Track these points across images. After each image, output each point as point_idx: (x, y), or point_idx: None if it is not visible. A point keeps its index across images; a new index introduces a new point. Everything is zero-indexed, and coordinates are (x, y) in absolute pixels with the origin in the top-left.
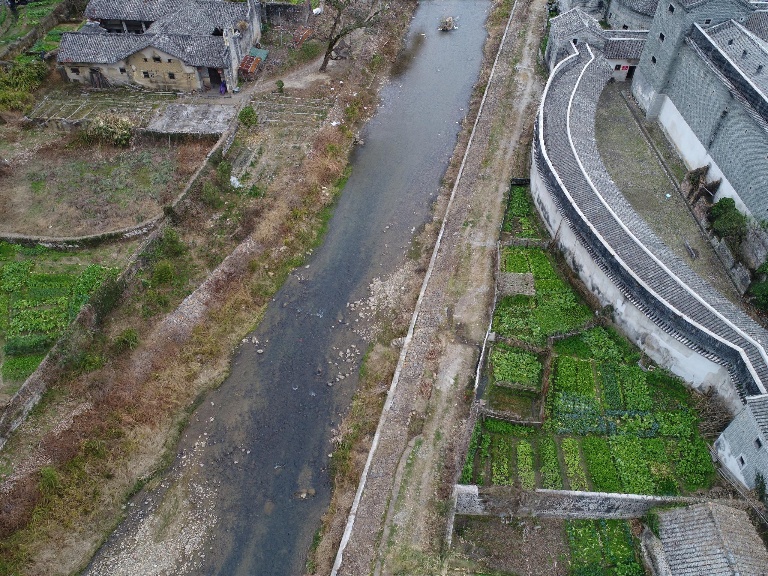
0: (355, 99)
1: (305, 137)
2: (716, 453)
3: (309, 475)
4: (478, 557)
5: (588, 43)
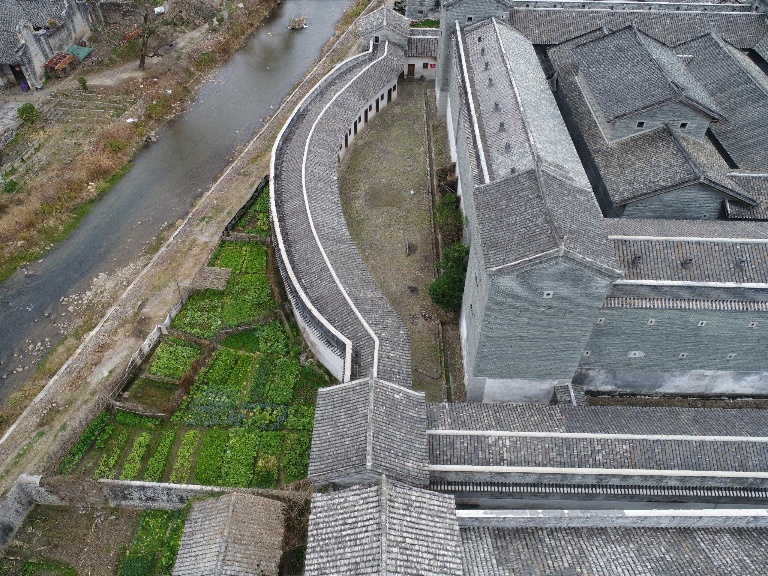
0: (163, 96)
1: (92, 133)
2: None
3: None
4: (37, 546)
5: (390, 41)
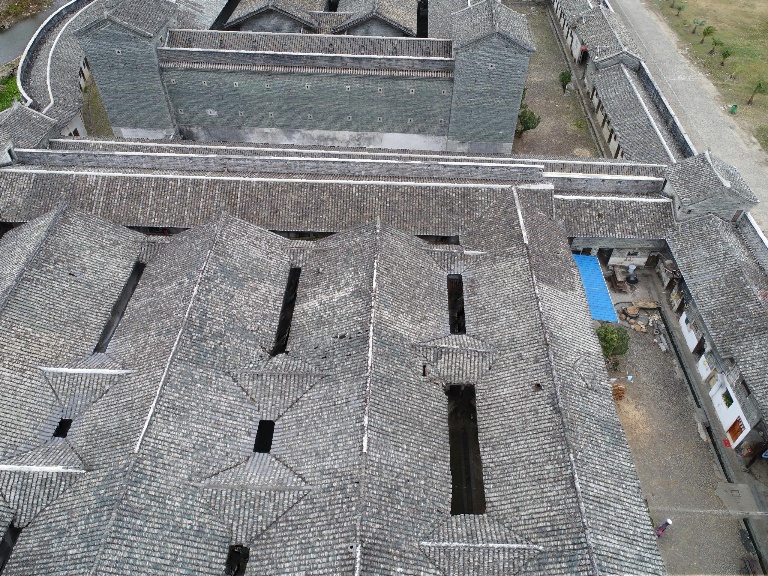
0: None
1: None
2: None
3: None
4: None
5: None
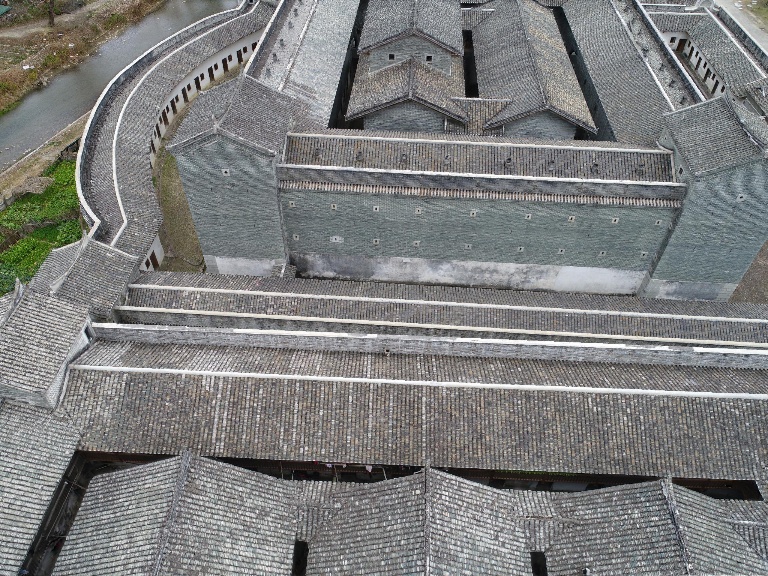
0: (63, 49)
1: None
2: None
3: None
4: None
5: (263, 1)
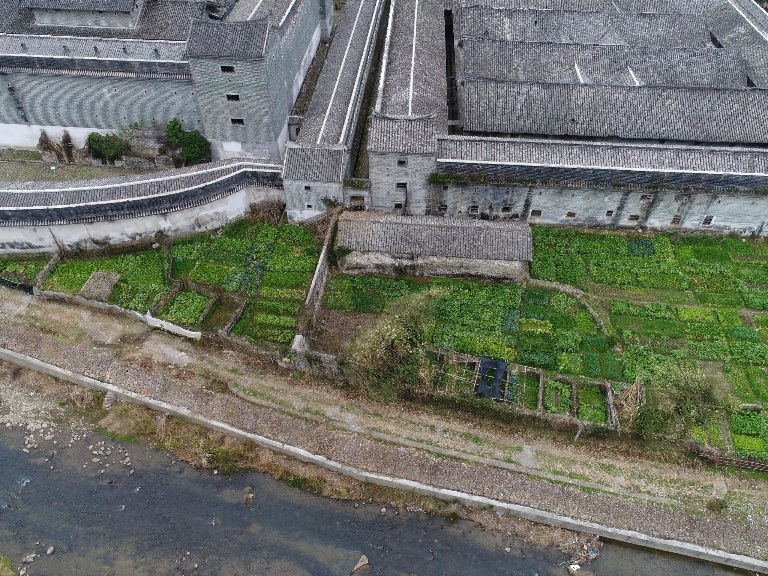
0: None
1: None
2: (294, 222)
3: (230, 492)
4: None
5: None
